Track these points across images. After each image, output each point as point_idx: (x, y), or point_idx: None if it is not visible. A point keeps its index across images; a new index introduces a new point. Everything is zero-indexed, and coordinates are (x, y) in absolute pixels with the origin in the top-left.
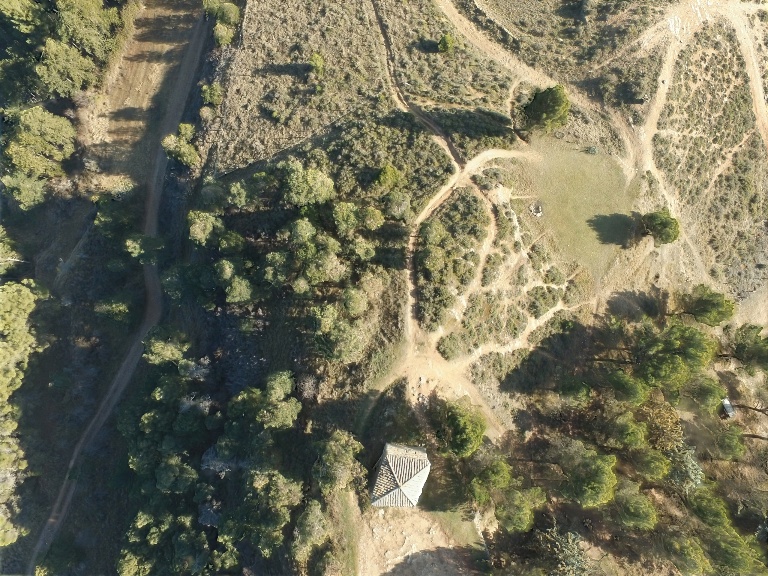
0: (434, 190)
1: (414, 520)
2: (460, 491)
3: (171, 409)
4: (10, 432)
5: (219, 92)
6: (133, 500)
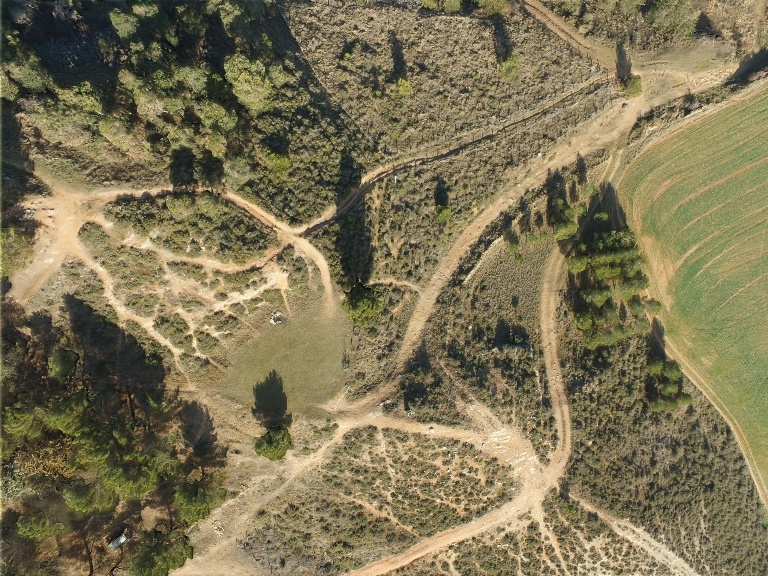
0: (268, 208)
1: None
2: None
3: None
4: None
5: (368, 1)
6: None
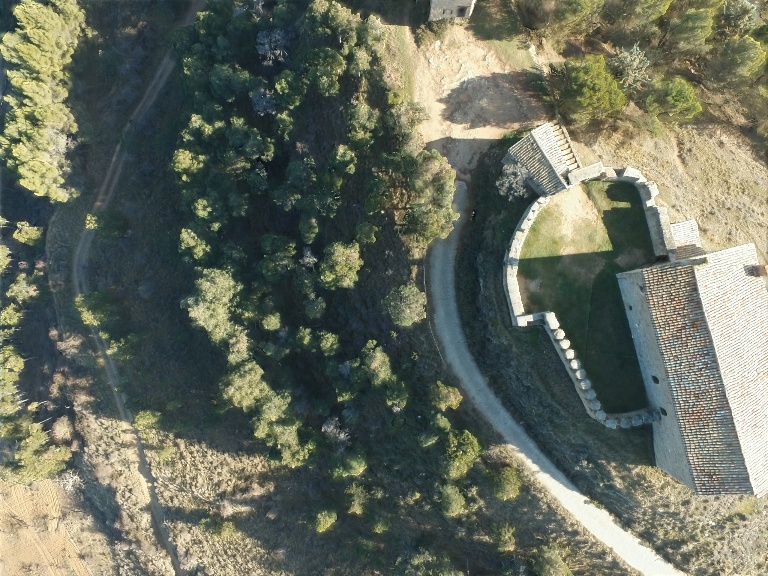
0: None
1: (470, 49)
2: (515, 25)
3: (224, 17)
4: (61, 100)
5: None
6: (184, 126)
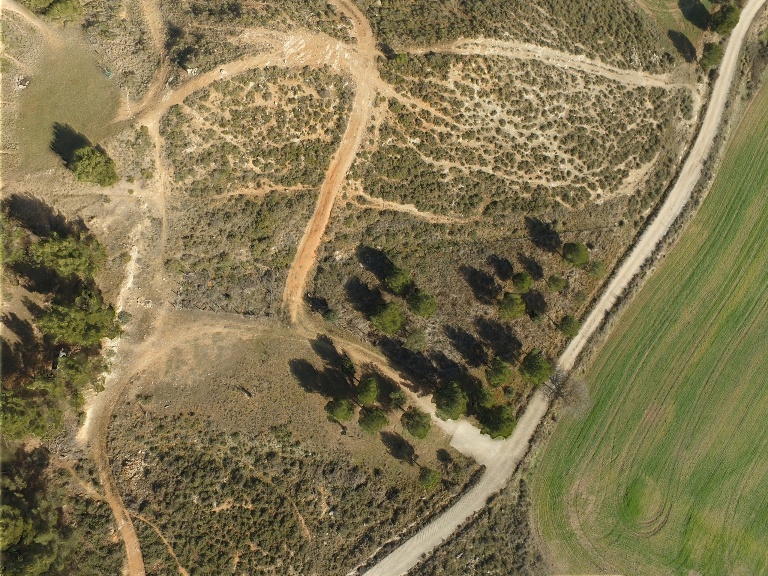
0: None
1: None
2: None
3: None
4: None
5: None
6: None
